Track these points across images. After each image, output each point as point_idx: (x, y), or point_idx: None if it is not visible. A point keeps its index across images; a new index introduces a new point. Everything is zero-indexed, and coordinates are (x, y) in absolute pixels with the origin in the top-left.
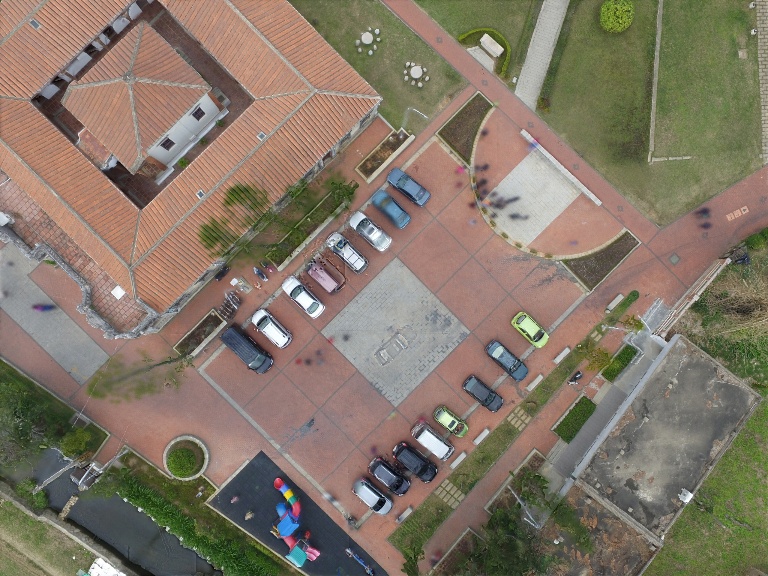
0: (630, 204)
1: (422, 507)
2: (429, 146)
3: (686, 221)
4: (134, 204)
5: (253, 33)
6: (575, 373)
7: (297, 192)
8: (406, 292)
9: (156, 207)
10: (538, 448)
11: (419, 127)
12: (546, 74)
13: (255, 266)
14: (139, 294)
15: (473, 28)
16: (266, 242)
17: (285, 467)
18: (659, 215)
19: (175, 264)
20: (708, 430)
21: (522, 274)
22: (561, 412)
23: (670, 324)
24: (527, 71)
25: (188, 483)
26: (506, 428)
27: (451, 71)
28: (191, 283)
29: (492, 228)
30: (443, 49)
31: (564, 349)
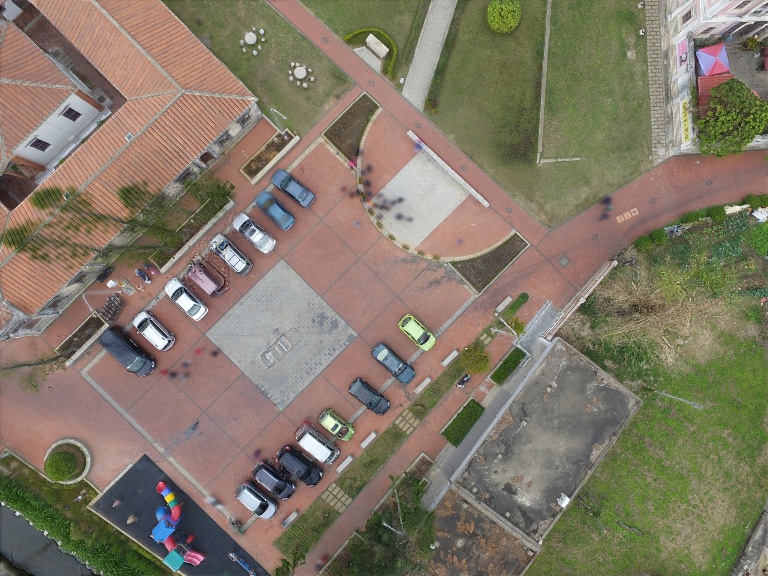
0: (519, 206)
1: (308, 511)
2: (315, 147)
3: (576, 223)
4: (4, 205)
5: (120, 33)
6: (464, 376)
7: (181, 193)
8: (292, 294)
9: (25, 208)
10: (426, 452)
11: (305, 128)
12: (434, 75)
13: (138, 268)
14: (5, 296)
15: (360, 28)
16: (150, 244)
17: (169, 471)
18: (549, 217)
19: (43, 266)
20: (588, 434)
21: (410, 276)
22: (450, 415)
23: (556, 327)
24: (414, 72)
25: (69, 487)
26: (394, 431)
27: (337, 71)
28: (62, 285)
29: (379, 230)
30: (329, 49)
31: (452, 352)
